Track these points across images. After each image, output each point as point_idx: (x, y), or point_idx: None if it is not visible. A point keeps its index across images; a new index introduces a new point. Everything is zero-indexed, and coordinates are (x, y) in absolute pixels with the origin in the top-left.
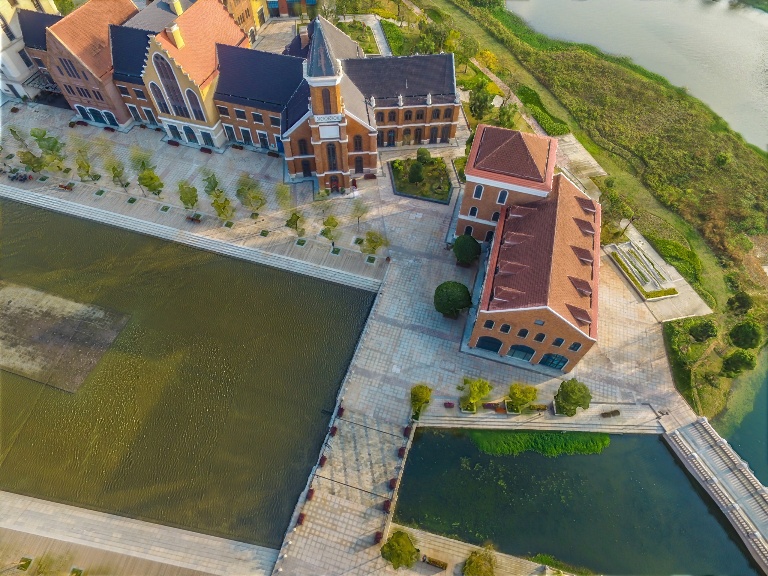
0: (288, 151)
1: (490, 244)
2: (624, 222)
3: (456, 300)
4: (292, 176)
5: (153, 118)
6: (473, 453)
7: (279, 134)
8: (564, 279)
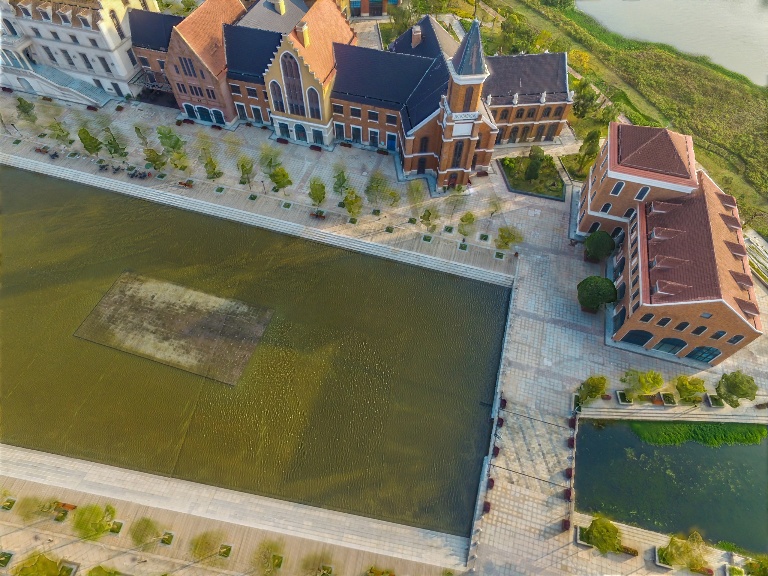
0: (409, 149)
1: (624, 240)
2: None
3: (607, 294)
4: (407, 173)
5: (260, 116)
6: (636, 444)
7: (392, 132)
8: (727, 273)
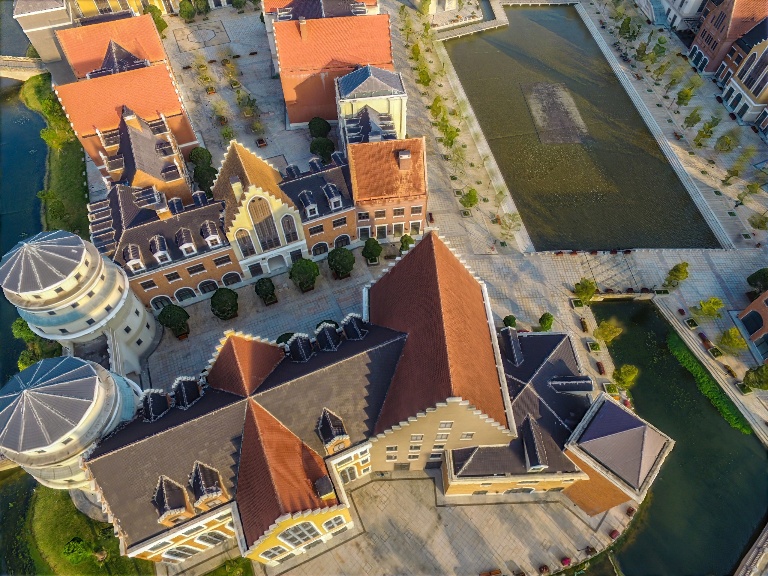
0: None
1: None
2: None
3: None
4: (766, 166)
5: (727, 80)
6: (661, 338)
7: None
8: None
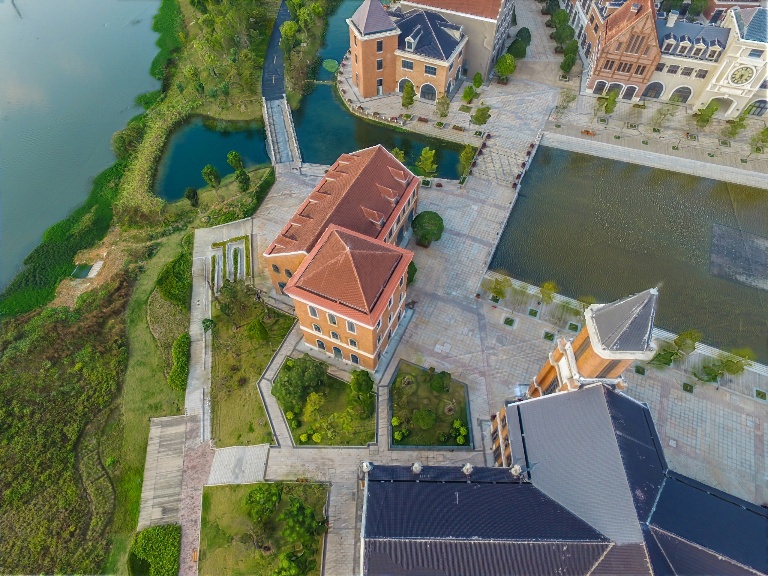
0: None
1: None
2: (197, 330)
3: None
4: None
5: None
6: None
7: None
8: None
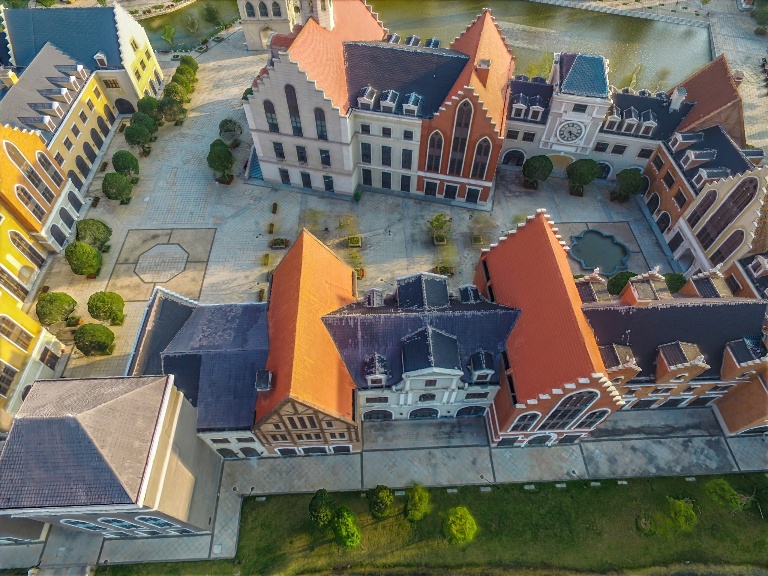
0: None
1: None
2: None
3: None
4: None
5: None
6: None
7: None
8: None
